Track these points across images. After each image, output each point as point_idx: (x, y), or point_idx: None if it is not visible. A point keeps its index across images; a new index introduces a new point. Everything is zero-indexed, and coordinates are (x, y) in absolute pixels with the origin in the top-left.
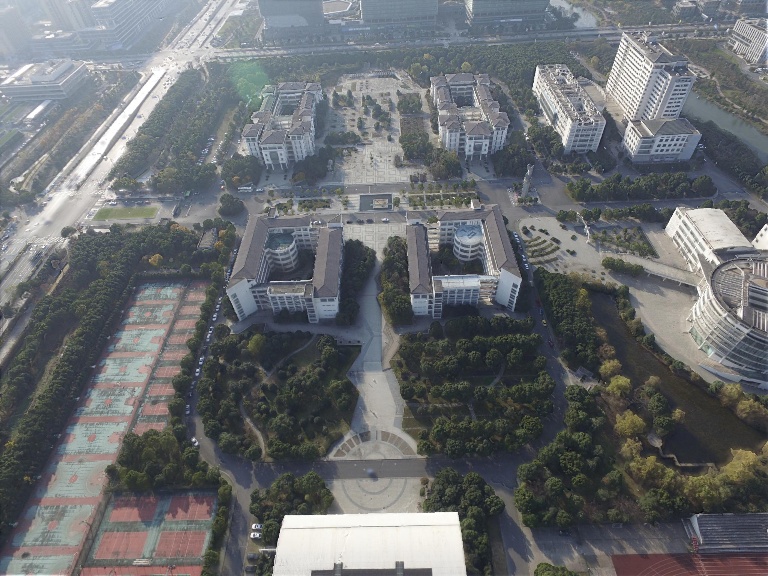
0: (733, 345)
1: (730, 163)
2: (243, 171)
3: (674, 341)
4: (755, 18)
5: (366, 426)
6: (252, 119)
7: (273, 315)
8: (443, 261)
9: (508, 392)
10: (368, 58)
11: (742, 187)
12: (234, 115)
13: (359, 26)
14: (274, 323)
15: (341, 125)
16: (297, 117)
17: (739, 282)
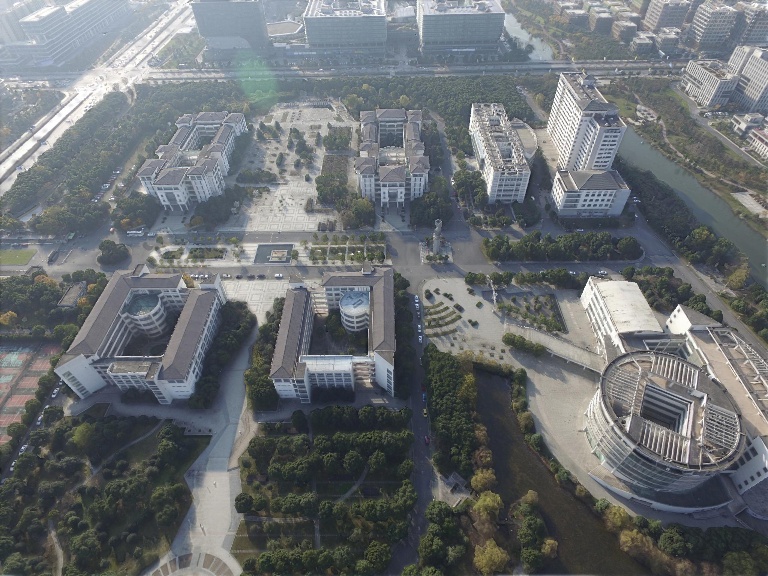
0: (621, 459)
1: (661, 222)
2: (135, 213)
3: (566, 441)
4: (708, 59)
5: (189, 546)
6: (156, 153)
7: (122, 392)
8: (329, 330)
9: (357, 510)
10: (306, 86)
11: (671, 249)
12: (146, 146)
13: (305, 50)
14: (120, 403)
15: (260, 160)
16: (205, 153)
17: (634, 382)
